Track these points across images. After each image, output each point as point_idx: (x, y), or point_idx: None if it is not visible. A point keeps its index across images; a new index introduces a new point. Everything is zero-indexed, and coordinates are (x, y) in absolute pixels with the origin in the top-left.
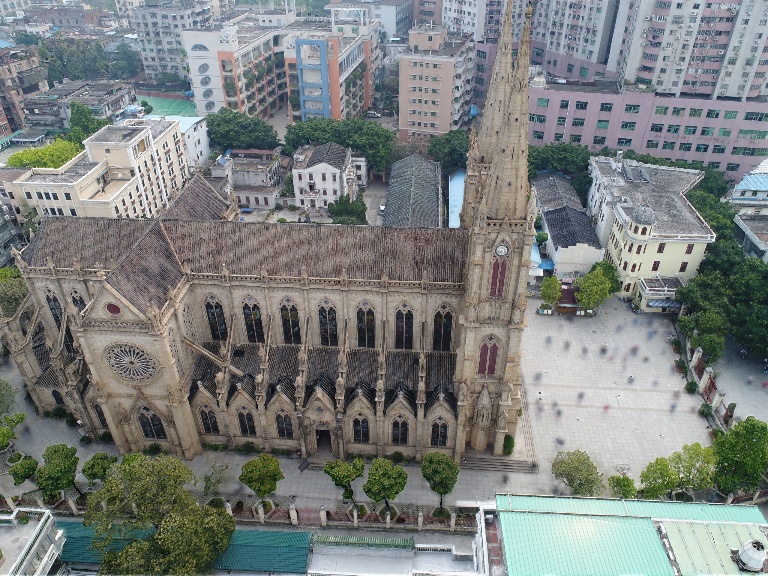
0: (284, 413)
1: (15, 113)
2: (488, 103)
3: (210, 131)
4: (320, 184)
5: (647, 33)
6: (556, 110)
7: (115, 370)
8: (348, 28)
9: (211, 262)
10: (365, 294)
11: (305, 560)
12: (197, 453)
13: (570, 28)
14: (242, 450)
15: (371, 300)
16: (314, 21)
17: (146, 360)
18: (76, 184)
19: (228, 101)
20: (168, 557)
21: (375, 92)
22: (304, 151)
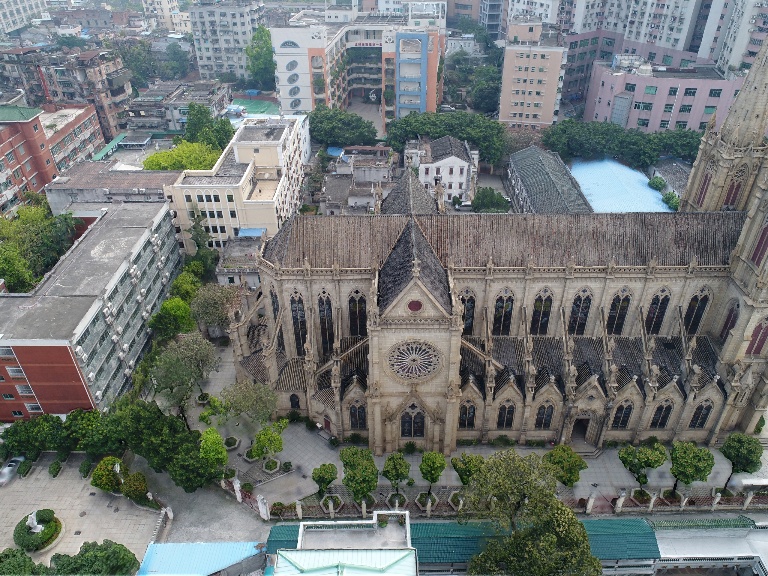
0: (548, 404)
1: (103, 116)
2: (751, 87)
3: (312, 129)
4: (446, 178)
5: (756, 19)
6: (664, 97)
7: (393, 369)
8: (425, 22)
9: (470, 256)
10: (627, 281)
11: (656, 545)
12: (453, 449)
13: (653, 17)
14: (497, 444)
15: (631, 287)
16: (377, 16)
17: (430, 357)
18: (241, 185)
19: (315, 98)
20: (579, 549)
21: (443, 86)
22: (420, 146)
